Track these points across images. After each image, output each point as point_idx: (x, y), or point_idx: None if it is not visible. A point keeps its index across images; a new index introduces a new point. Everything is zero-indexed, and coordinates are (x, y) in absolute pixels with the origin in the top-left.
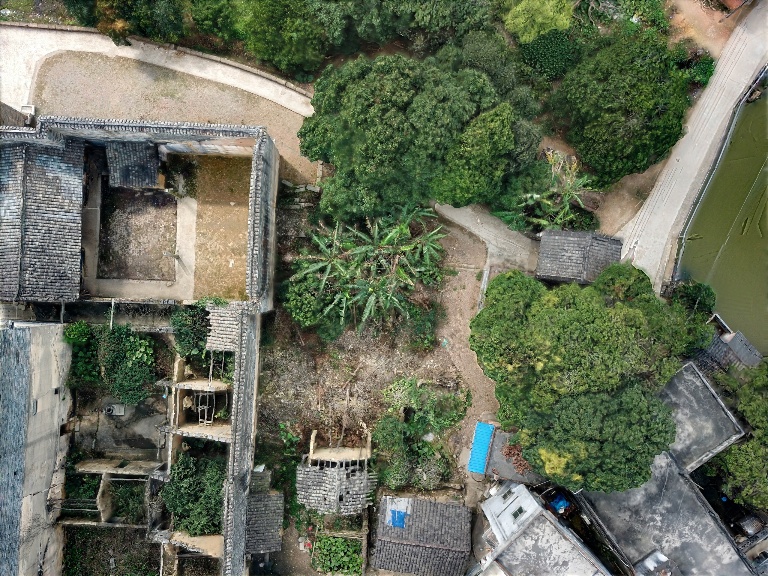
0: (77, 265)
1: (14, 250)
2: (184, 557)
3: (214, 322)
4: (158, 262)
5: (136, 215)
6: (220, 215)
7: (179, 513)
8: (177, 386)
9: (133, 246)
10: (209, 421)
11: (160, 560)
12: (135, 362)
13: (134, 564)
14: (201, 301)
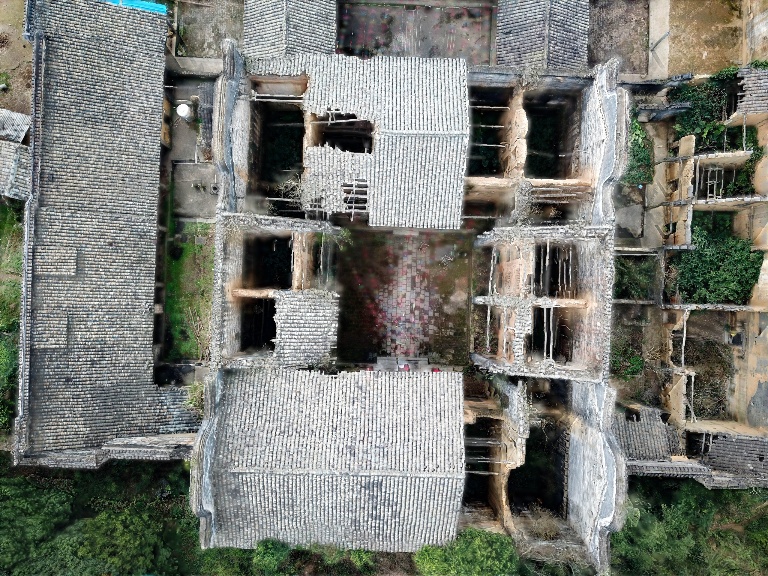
0: (585, 44)
1: (537, 24)
2: (677, 337)
3: (750, 86)
4: (629, 56)
5: (607, 10)
6: (692, 8)
7: (688, 287)
8: (697, 157)
9: (605, 40)
10: (718, 196)
11: (642, 346)
12: (633, 144)
13: (617, 350)
14: (724, 72)
